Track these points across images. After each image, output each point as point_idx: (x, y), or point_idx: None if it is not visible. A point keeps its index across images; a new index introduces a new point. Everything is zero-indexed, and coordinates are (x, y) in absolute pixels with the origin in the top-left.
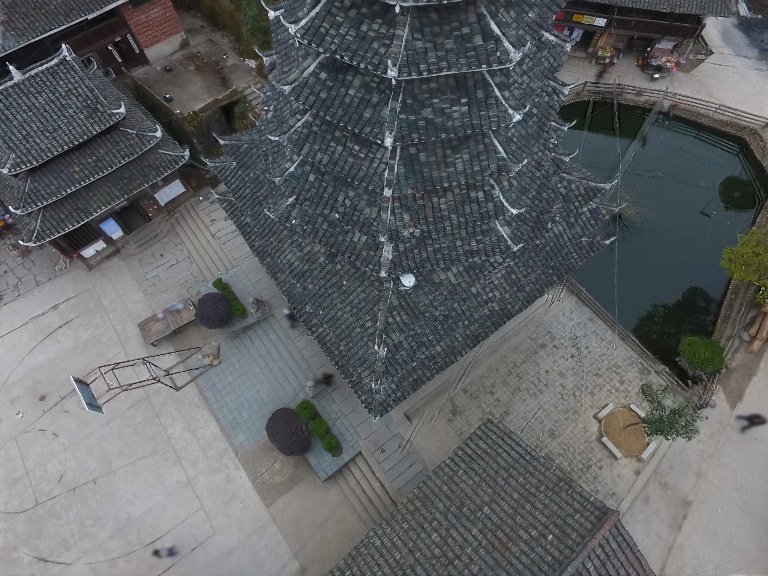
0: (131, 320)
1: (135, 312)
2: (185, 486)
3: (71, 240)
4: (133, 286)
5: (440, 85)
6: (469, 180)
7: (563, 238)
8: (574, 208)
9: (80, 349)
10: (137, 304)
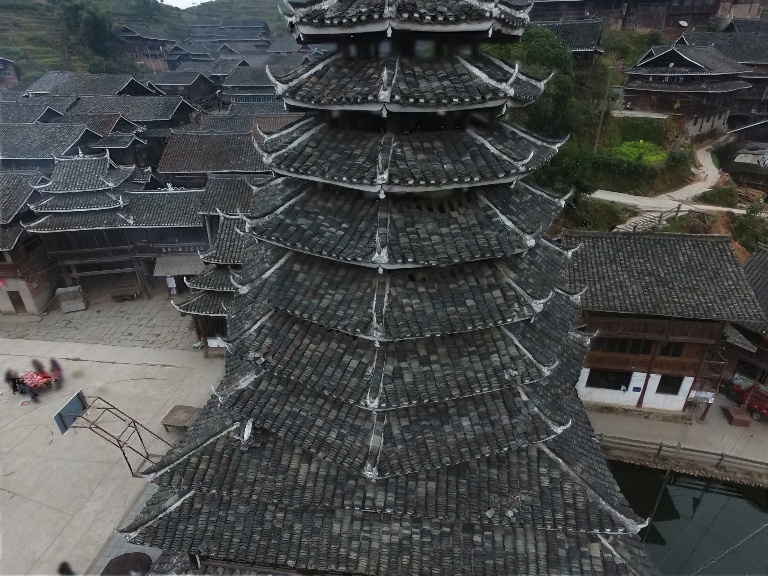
0: (181, 403)
1: (190, 400)
2: (30, 562)
3: (208, 326)
4: (211, 383)
5: (334, 206)
6: (322, 320)
7: (528, 568)
8: (551, 519)
9: (137, 399)
10: (197, 396)
